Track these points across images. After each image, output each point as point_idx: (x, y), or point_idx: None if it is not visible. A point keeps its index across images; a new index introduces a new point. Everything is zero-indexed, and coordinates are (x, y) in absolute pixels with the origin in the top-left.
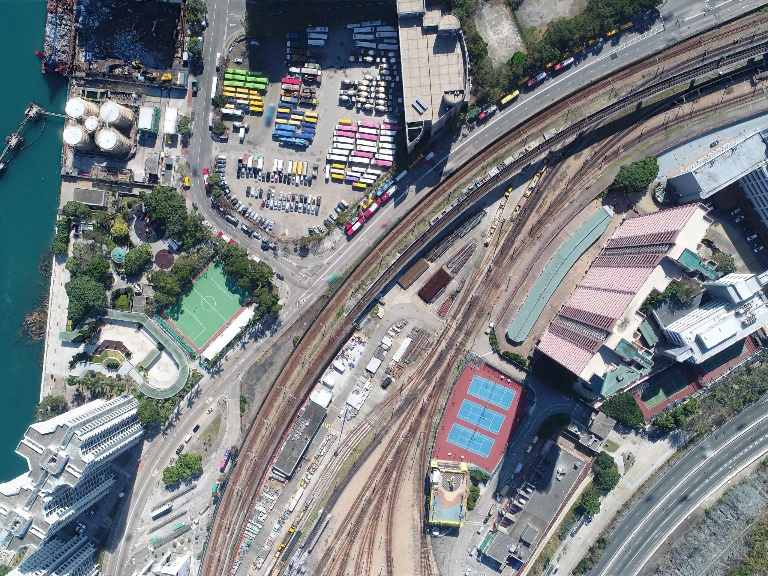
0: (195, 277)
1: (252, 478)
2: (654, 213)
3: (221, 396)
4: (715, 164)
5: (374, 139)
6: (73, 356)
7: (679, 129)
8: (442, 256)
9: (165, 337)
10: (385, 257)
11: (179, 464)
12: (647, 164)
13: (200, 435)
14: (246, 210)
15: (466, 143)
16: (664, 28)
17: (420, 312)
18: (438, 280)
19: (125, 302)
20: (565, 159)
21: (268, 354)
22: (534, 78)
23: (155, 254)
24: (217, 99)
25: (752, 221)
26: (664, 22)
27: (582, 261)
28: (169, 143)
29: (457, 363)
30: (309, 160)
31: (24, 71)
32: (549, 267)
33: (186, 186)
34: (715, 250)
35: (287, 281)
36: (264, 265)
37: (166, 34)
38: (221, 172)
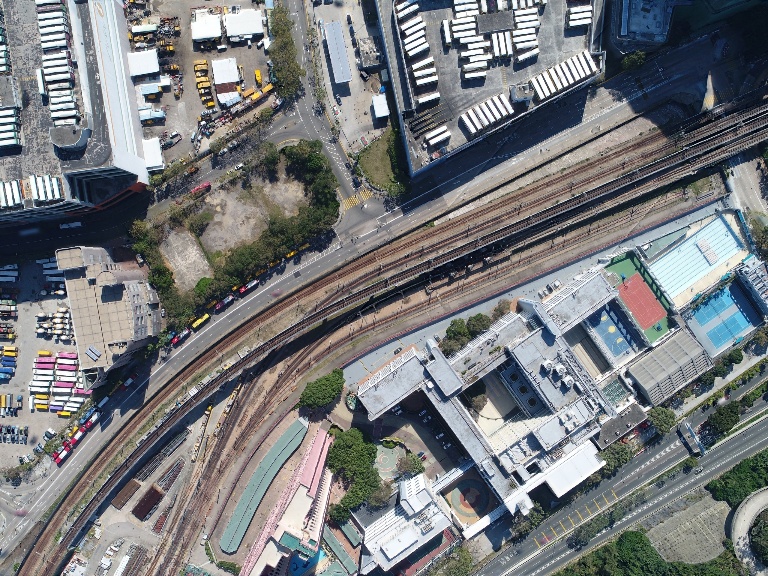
0: None
1: None
2: None
3: None
4: (379, 387)
5: (73, 369)
6: None
7: (364, 339)
8: (152, 474)
9: None
10: (97, 480)
11: None
12: (329, 381)
13: None
14: None
15: (165, 365)
16: (341, 245)
17: (136, 530)
18: (149, 499)
19: None
20: (260, 374)
21: None
22: (221, 302)
23: None
24: None
25: (438, 421)
26: (340, 240)
27: (286, 469)
28: None
29: (177, 575)
30: (13, 391)
31: None
32: (253, 479)
33: None
34: (407, 450)
35: (2, 510)
36: None
37: None
38: None
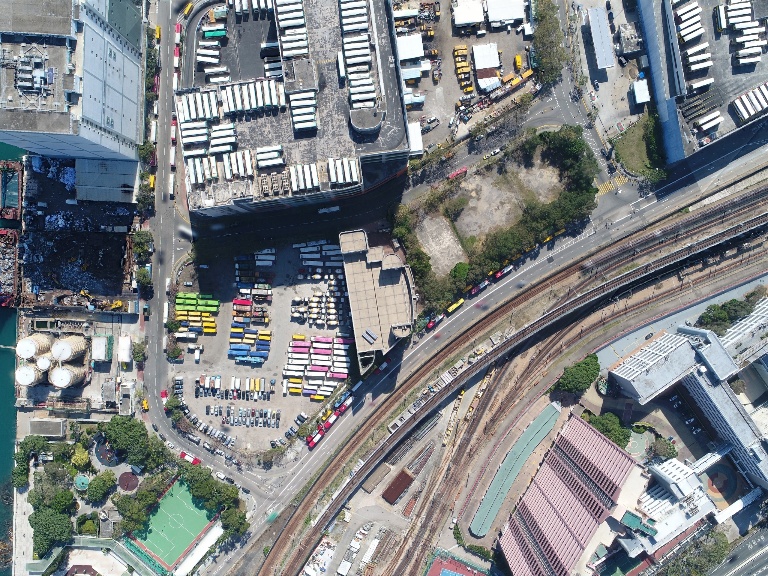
0: (161, 496)
1: None
2: (597, 434)
3: None
4: (650, 372)
5: (328, 353)
6: None
7: (616, 324)
8: (402, 458)
9: (135, 560)
10: (347, 463)
11: None
12: (589, 365)
13: None
14: (207, 428)
15: (417, 349)
16: (595, 231)
17: (385, 513)
18: (400, 483)
19: (91, 527)
20: (512, 359)
21: (240, 565)
22: (477, 286)
23: (118, 477)
24: (170, 325)
25: (689, 406)
26: (594, 226)
27: (535, 454)
28: (124, 368)
29: (425, 559)
30: (266, 375)
31: None
32: (505, 463)
33: (145, 409)
34: (657, 435)
35: (253, 494)
36: (229, 485)
37: (113, 264)
38: (179, 393)
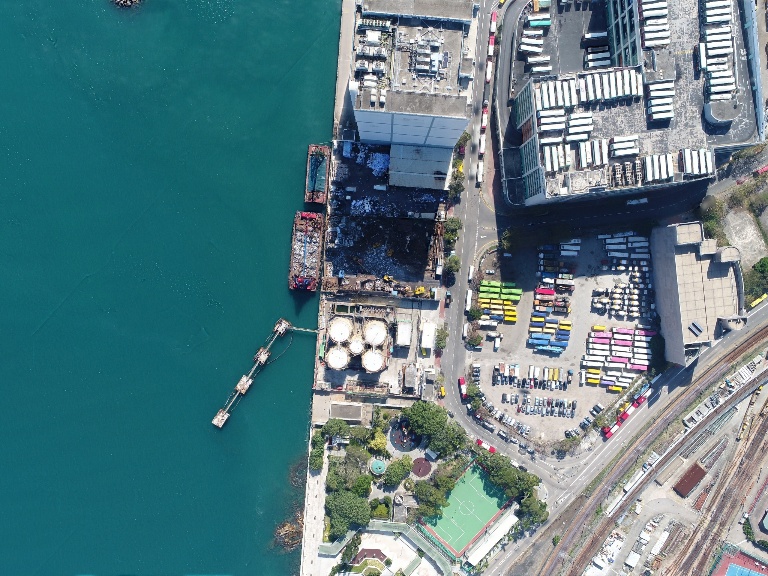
0: None
1: None
2: None
3: None
4: None
5: (629, 345)
6: (333, 568)
7: None
8: (696, 452)
9: (428, 545)
10: (640, 455)
11: None
12: None
13: None
14: (502, 416)
15: None
16: None
17: (676, 506)
18: (694, 476)
19: (384, 512)
20: None
21: (528, 554)
22: None
23: None
24: (474, 312)
25: None
26: None
27: None
28: (424, 354)
29: (713, 553)
30: (563, 365)
31: (269, 286)
32: None
33: (442, 396)
34: None
35: (545, 483)
36: (530, 474)
37: (420, 250)
38: (477, 381)
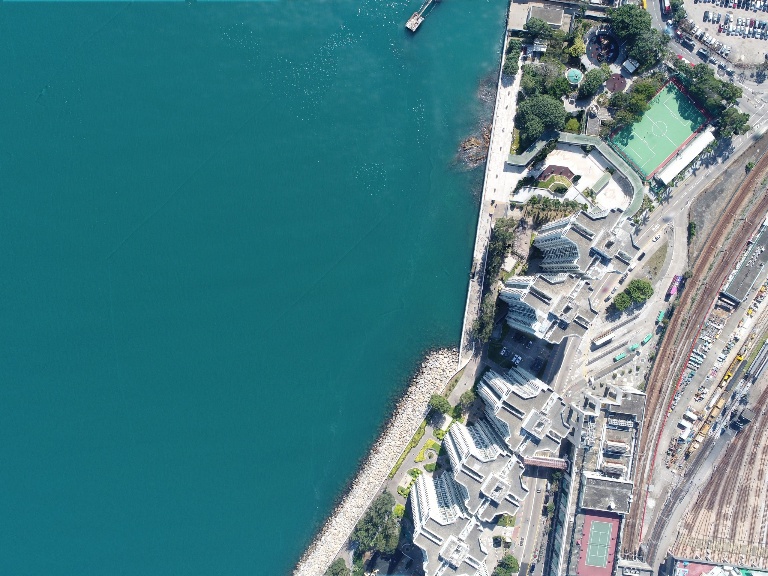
0: (647, 102)
1: (700, 306)
2: None
3: (668, 224)
4: None
5: None
6: (520, 180)
7: None
8: None
9: (620, 160)
10: None
11: (632, 289)
12: None
13: (645, 263)
14: (703, 35)
15: None
16: None
17: None
18: None
19: (575, 126)
20: None
21: (719, 181)
22: None
23: None
24: None
25: None
26: None
27: None
28: None
29: None
30: None
31: None
32: None
33: None
34: None
35: (742, 107)
36: None
37: None
38: None
